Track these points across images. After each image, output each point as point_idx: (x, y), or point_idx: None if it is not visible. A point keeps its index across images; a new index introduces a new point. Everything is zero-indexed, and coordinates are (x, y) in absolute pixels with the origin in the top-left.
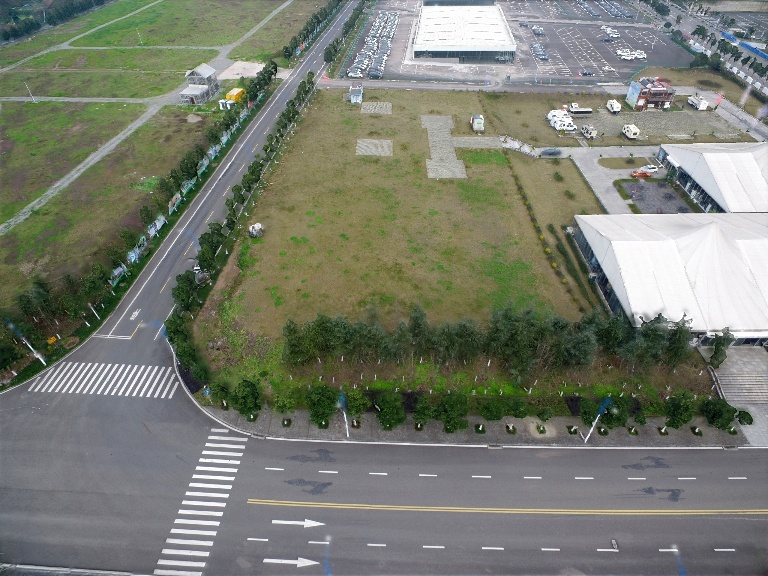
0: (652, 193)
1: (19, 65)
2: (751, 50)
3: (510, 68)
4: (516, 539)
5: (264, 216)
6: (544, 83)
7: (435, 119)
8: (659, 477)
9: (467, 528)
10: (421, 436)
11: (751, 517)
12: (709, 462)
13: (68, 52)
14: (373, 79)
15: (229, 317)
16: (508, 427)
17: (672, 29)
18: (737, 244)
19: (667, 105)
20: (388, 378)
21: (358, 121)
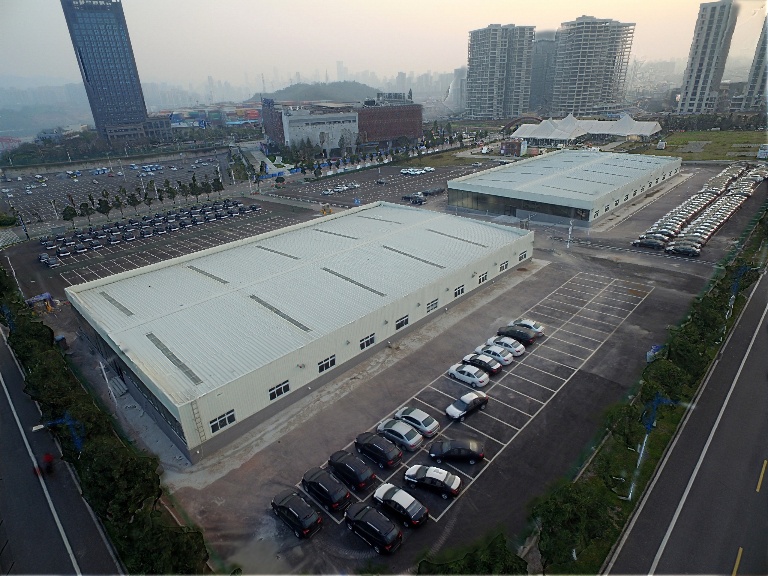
0: None
1: None
2: None
3: None
4: None
5: None
6: None
7: None
8: None
9: None
10: None
11: None
12: None
13: None
14: None
15: None
16: None
17: None
18: None
19: None
20: None
21: None
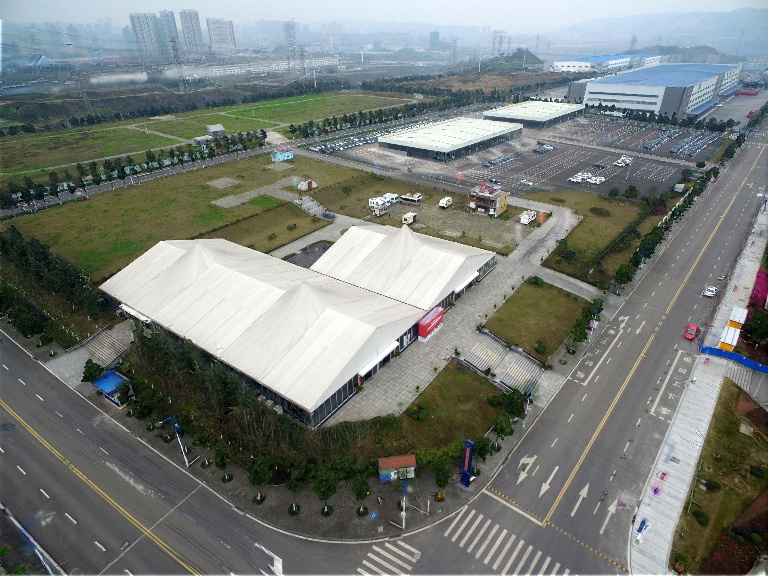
0: None
1: (183, 118)
2: None
3: (441, 166)
4: None
5: None
6: (439, 179)
7: (296, 179)
8: None
9: None
10: None
11: None
12: (13, 356)
13: None
14: (320, 153)
15: None
16: None
17: None
18: (212, 265)
19: (492, 212)
20: None
21: None
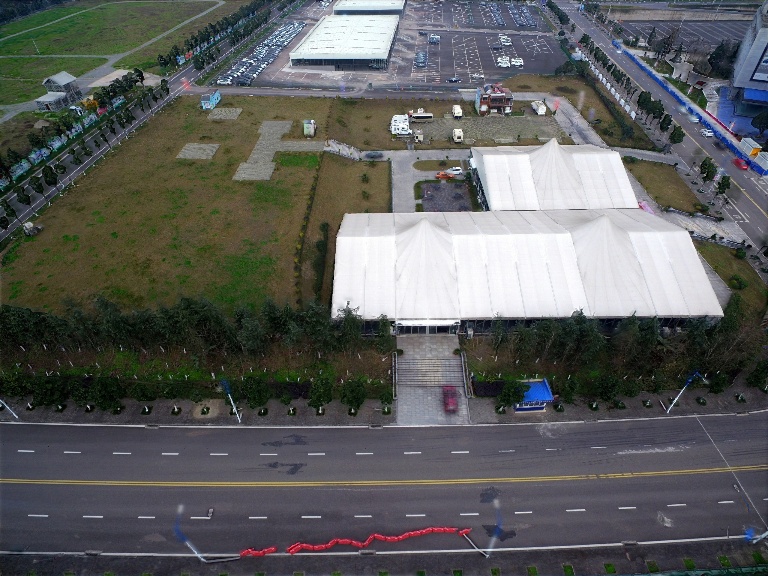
0: (445, 193)
1: None
2: (630, 57)
3: (383, 75)
4: (119, 508)
5: (51, 216)
6: (406, 89)
7: (275, 124)
8: (291, 453)
9: (79, 499)
10: (87, 417)
11: (354, 488)
12: (347, 439)
13: None
14: (239, 86)
15: None
16: (174, 409)
17: (568, 37)
18: (451, 239)
19: (508, 110)
20: (85, 365)
21: (198, 126)
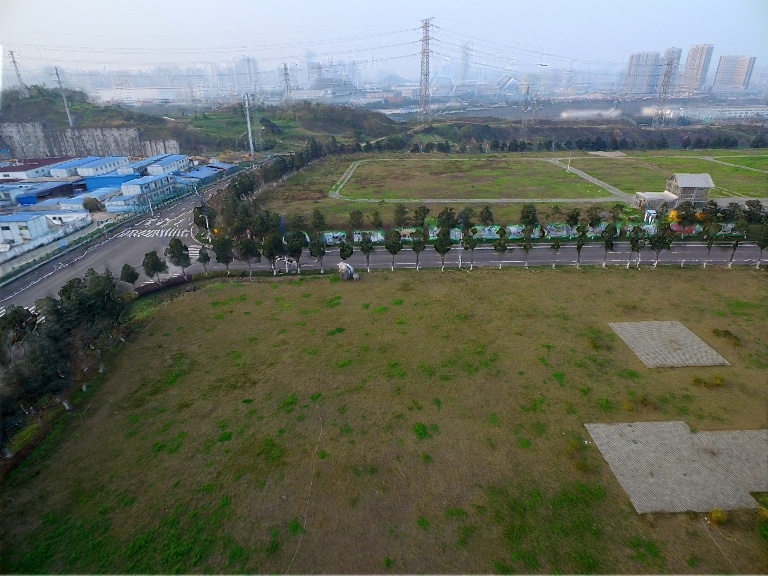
0: None
1: None
2: None
3: None
4: None
5: (388, 277)
6: None
7: None
8: None
9: None
10: None
11: None
12: None
13: (694, 160)
14: None
15: (213, 285)
16: None
17: None
18: None
19: None
20: (50, 400)
21: (764, 315)
